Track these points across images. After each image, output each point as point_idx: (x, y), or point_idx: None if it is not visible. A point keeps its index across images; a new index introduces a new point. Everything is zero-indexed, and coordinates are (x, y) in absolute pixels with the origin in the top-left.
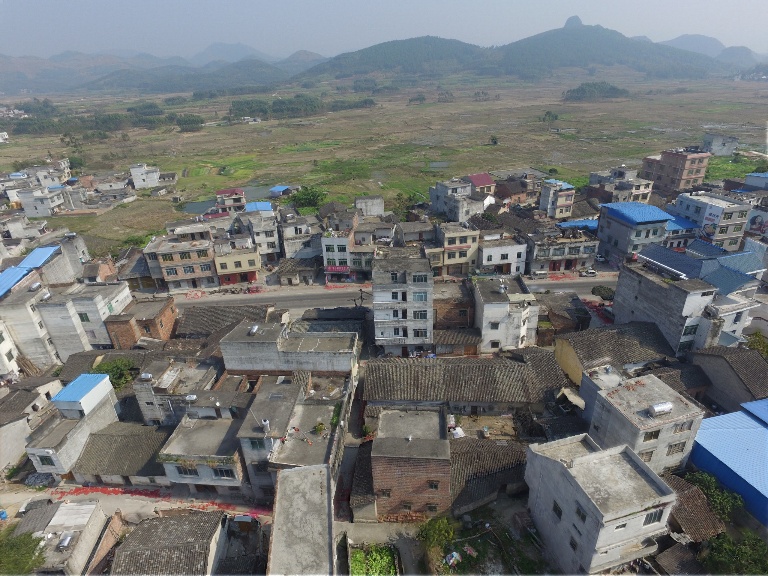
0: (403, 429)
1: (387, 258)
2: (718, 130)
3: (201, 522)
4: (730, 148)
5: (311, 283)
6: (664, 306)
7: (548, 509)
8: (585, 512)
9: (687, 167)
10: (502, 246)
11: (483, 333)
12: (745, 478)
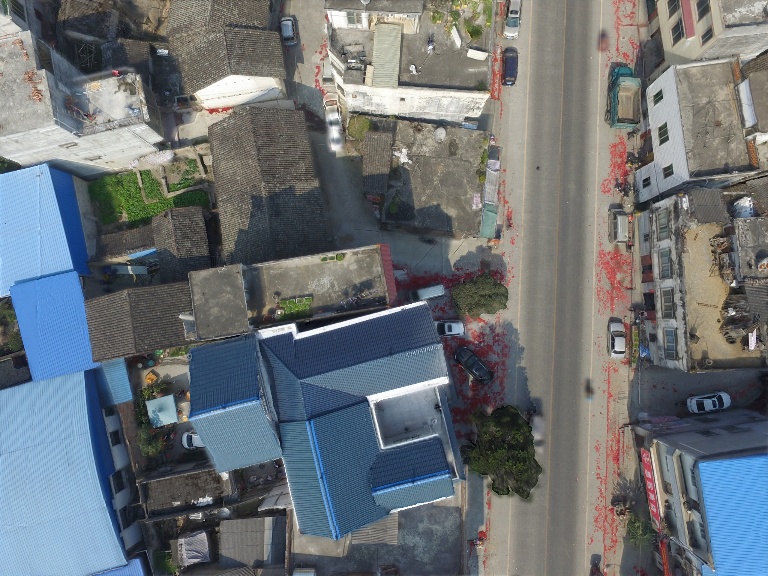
0: None
1: None
2: None
3: None
4: None
5: None
6: None
7: None
8: None
9: None
10: None
11: None
12: None
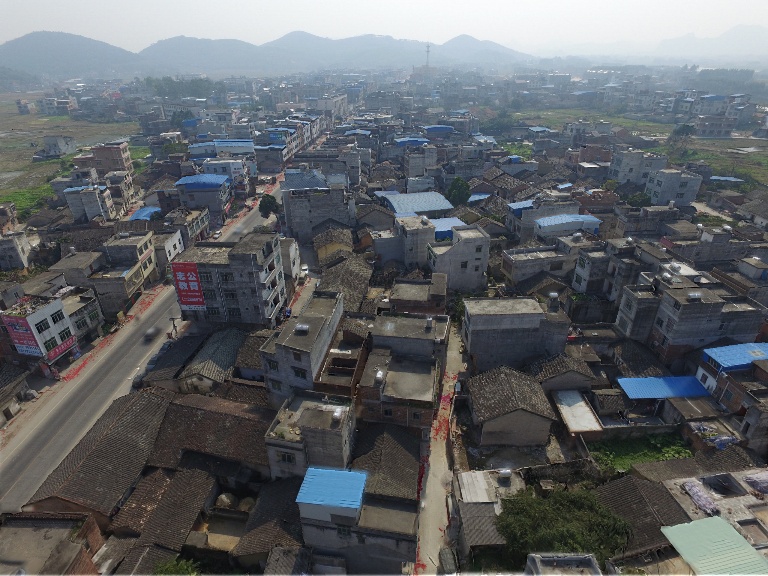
0: (410, 295)
1: (197, 261)
2: (6, 138)
3: (482, 382)
4: (73, 146)
5: (36, 393)
6: (332, 205)
7: (458, 271)
8: (482, 245)
9: (123, 156)
10: (170, 238)
11: (292, 273)
12: (443, 230)
